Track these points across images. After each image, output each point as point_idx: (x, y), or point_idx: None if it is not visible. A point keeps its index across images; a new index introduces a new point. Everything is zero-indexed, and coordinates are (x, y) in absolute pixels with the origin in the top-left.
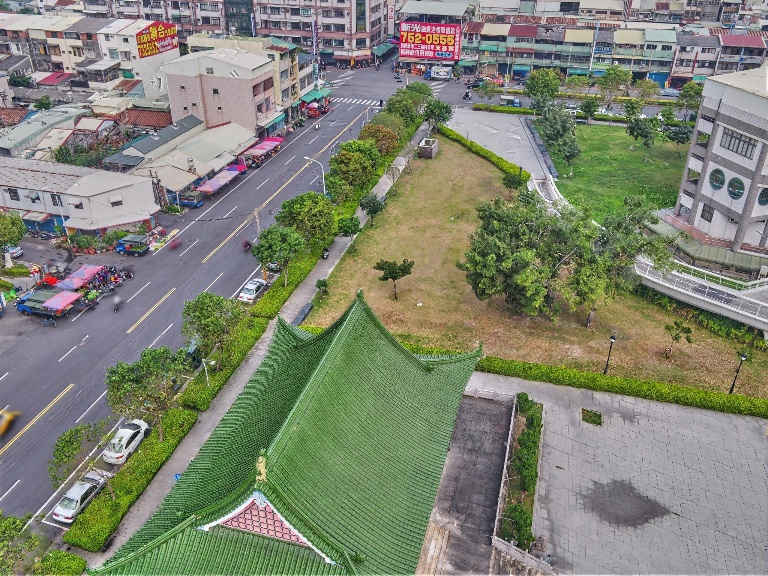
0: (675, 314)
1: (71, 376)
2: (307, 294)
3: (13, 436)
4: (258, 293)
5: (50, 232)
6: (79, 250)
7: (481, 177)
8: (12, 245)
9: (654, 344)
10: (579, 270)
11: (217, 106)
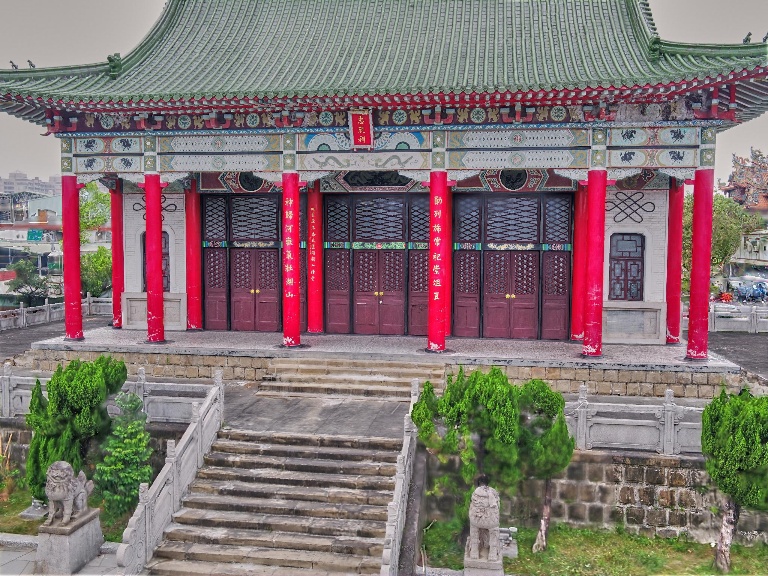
0: None
1: None
2: None
3: None
4: None
5: None
6: None
7: None
8: (715, 256)
9: None
10: None
11: None
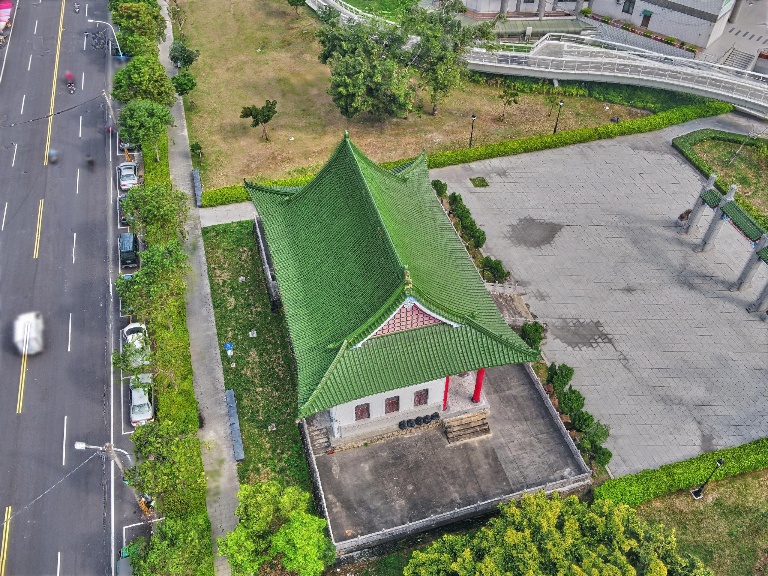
0: (488, 85)
1: (18, 317)
2: (183, 162)
3: (17, 388)
4: (137, 176)
5: None
6: None
7: (254, 0)
8: None
9: (487, 113)
10: (429, 68)
11: None
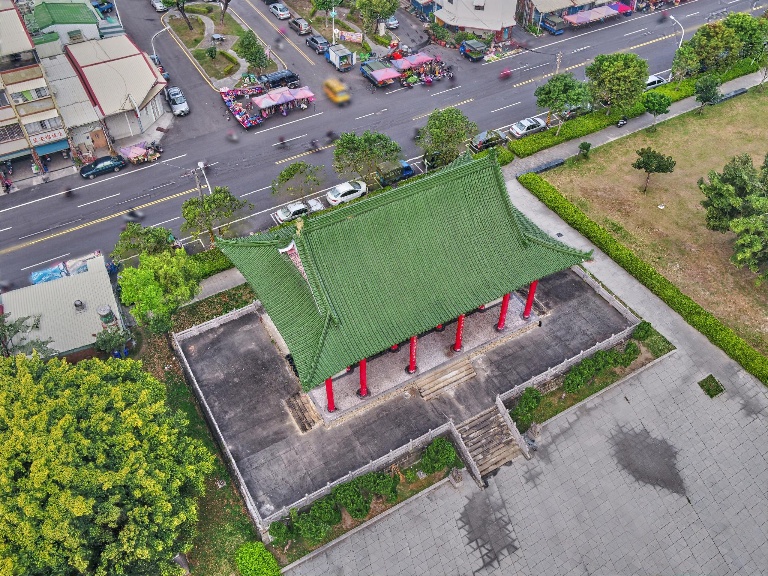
0: None
1: None
2: (570, 151)
3: None
4: (529, 131)
5: (427, 16)
6: (435, 39)
7: None
8: (384, 17)
9: None
10: None
11: None
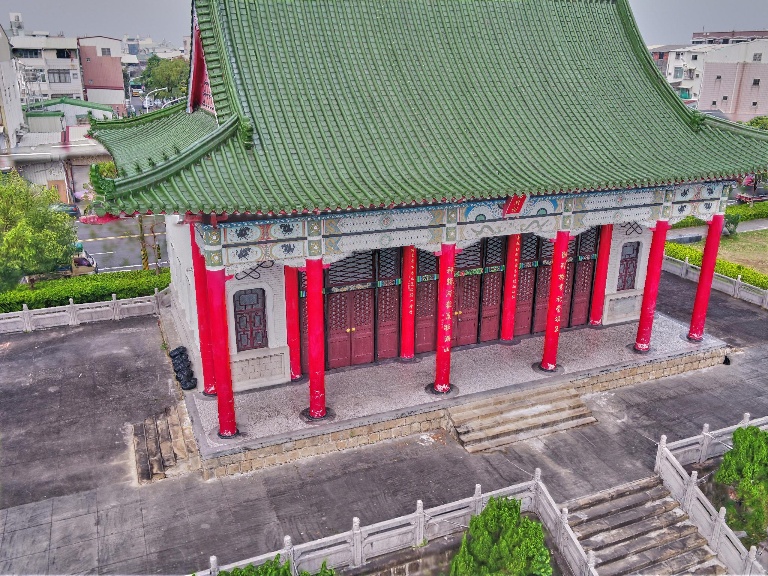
0: None
1: None
2: (706, 232)
3: None
4: None
5: None
6: None
7: None
8: None
9: None
10: None
11: (752, 101)
